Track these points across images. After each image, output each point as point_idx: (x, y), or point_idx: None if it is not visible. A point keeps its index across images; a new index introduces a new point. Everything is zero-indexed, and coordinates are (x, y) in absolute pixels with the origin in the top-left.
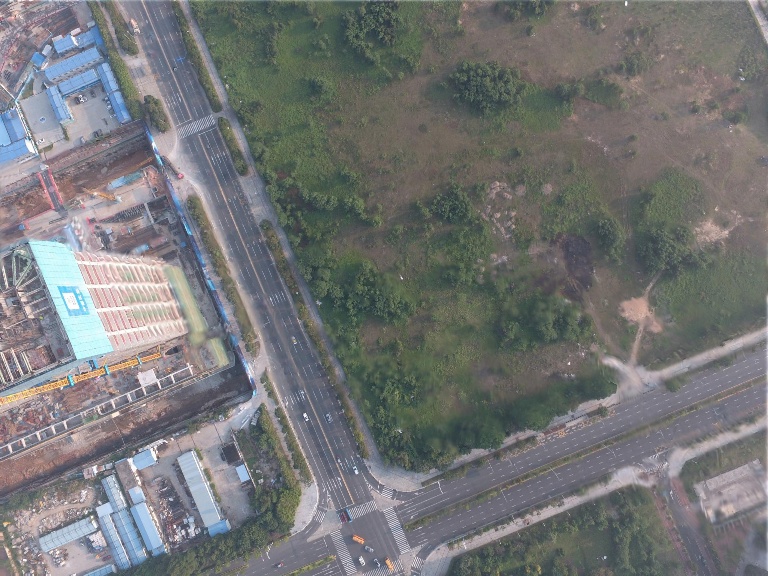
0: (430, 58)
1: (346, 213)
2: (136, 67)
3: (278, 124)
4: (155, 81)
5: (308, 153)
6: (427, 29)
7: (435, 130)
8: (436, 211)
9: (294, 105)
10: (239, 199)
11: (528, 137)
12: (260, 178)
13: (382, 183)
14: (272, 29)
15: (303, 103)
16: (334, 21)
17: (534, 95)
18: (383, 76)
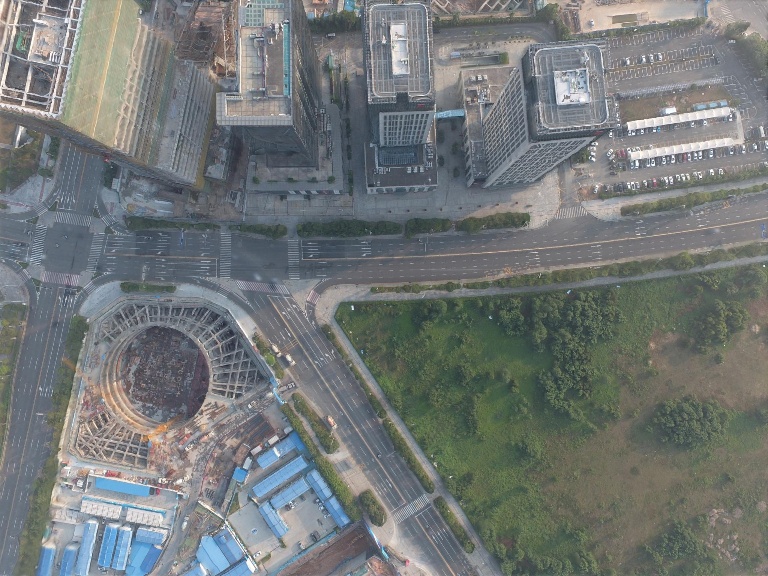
0: (628, 402)
1: (581, 573)
2: (339, 461)
3: (492, 492)
4: (361, 471)
5: (528, 515)
6: (620, 374)
7: (646, 470)
8: (666, 554)
9: (505, 470)
10: (468, 572)
11: (735, 460)
12: (487, 551)
13: (606, 532)
14: (469, 400)
15: (513, 467)
16: (528, 381)
17: (734, 420)
18: (587, 428)
